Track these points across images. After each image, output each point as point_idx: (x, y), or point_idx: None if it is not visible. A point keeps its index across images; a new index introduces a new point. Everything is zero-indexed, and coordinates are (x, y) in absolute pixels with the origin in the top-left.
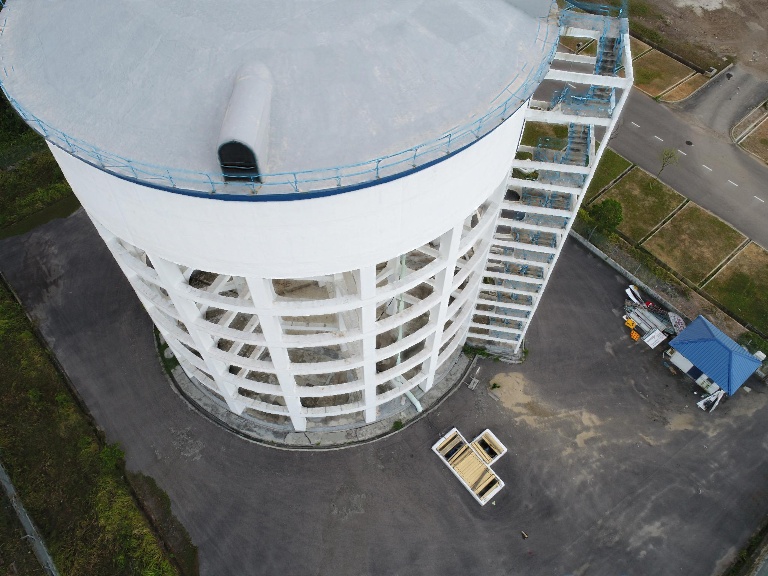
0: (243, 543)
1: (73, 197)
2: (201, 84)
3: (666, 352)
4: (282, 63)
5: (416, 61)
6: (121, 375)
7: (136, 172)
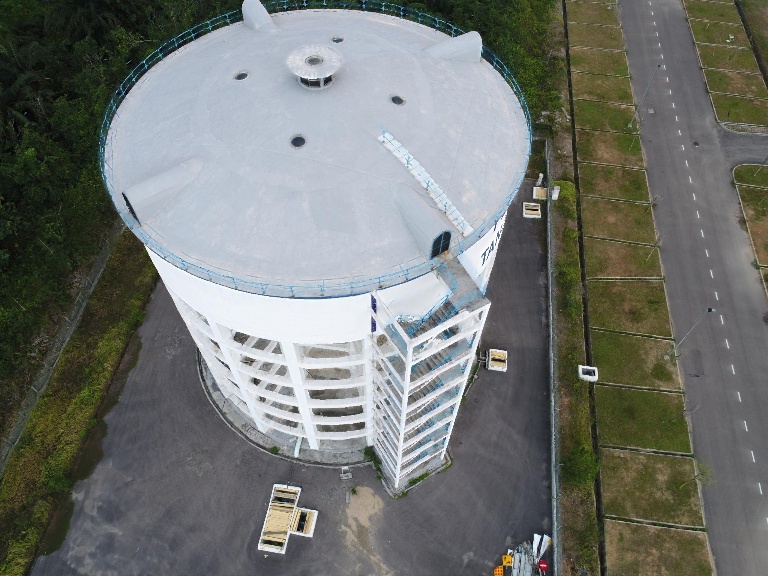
0: (136, 424)
1: None
2: (173, 152)
3: None
4: (211, 169)
5: (280, 221)
6: None
7: (111, 176)
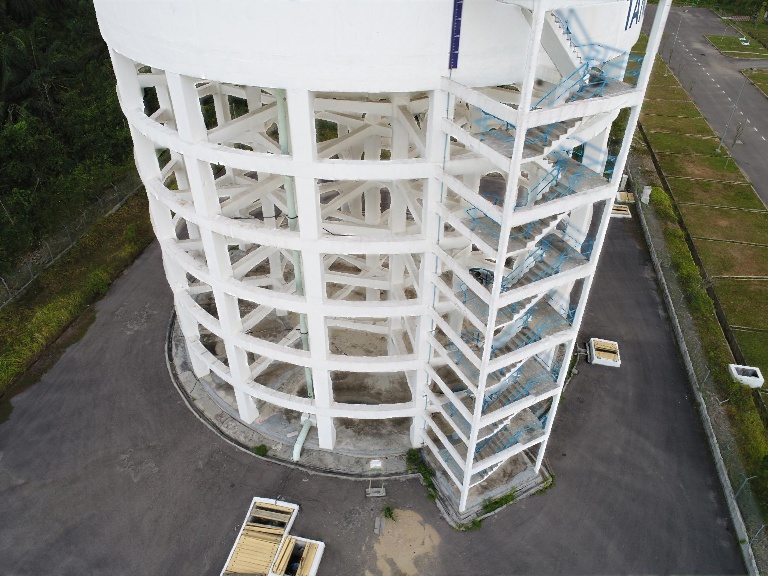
0: (57, 407)
1: None
2: None
3: None
4: None
5: None
6: None
7: None
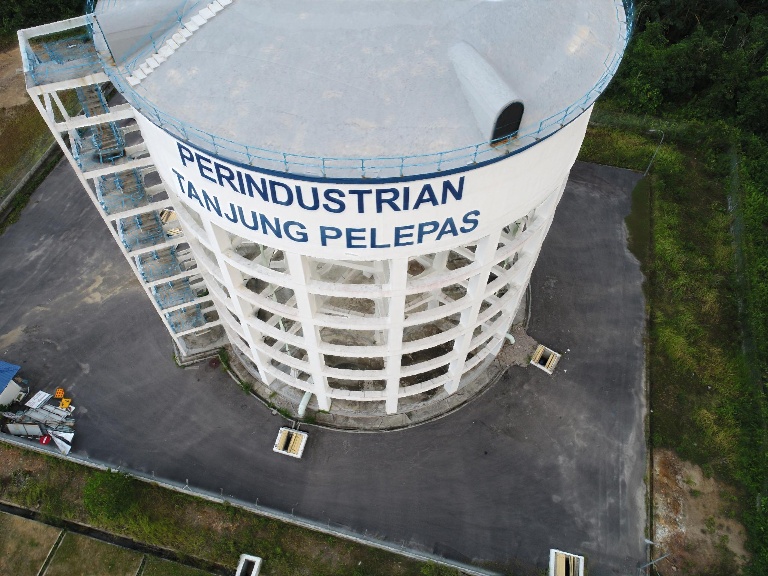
0: None
1: (646, 234)
2: None
3: (26, 394)
4: None
5: None
6: None
7: None
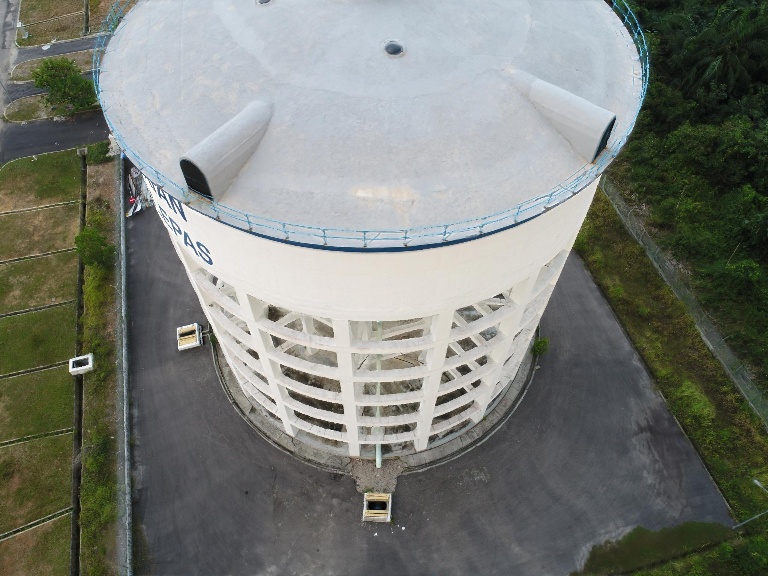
0: None
1: (633, 562)
2: None
3: None
4: None
5: None
6: (571, 304)
7: None
